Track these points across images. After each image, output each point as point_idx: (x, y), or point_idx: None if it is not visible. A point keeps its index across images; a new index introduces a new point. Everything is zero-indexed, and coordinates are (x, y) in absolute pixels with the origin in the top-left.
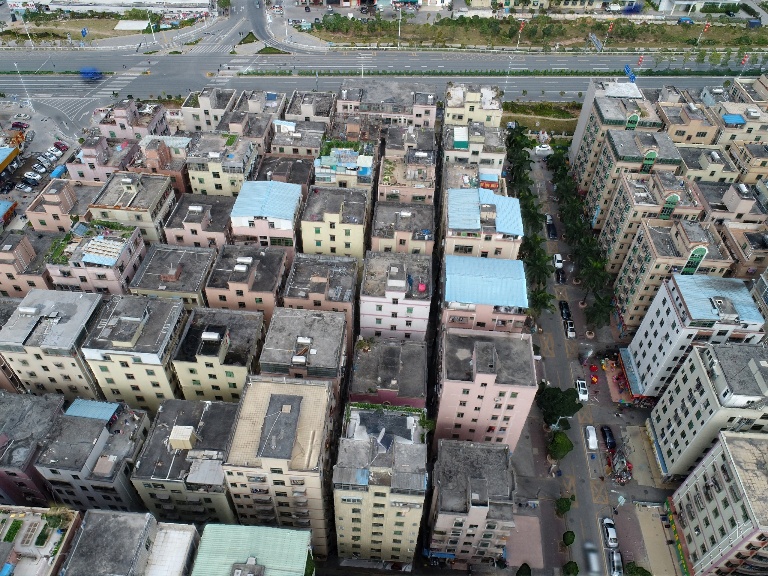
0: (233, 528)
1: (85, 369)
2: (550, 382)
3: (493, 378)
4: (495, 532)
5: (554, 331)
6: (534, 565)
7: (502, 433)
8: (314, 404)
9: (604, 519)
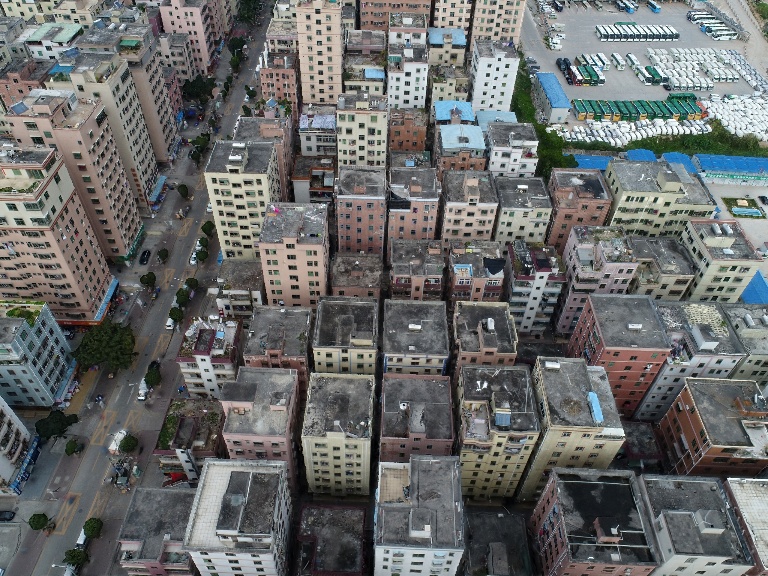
0: (54, 23)
1: (2, 13)
2: (249, 55)
3: (178, 2)
4: (177, 60)
5: (261, 41)
6: (212, 99)
7: (198, 45)
8: (94, 1)
9: (250, 87)
